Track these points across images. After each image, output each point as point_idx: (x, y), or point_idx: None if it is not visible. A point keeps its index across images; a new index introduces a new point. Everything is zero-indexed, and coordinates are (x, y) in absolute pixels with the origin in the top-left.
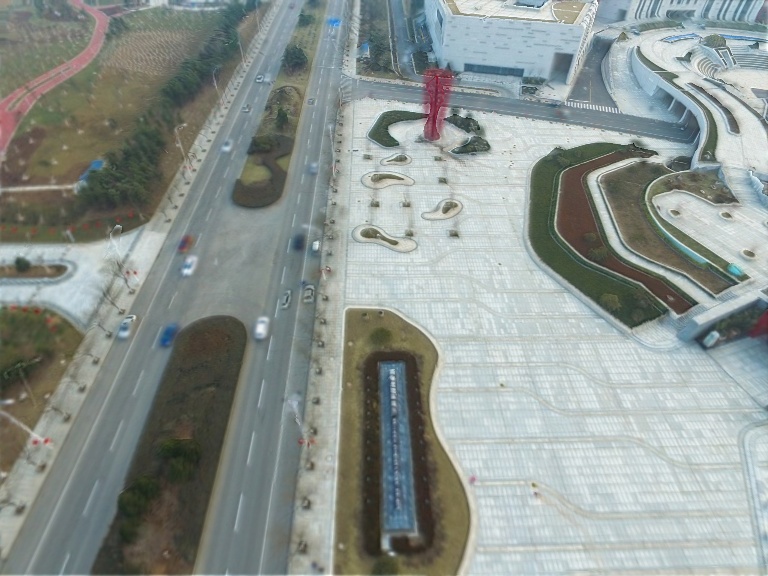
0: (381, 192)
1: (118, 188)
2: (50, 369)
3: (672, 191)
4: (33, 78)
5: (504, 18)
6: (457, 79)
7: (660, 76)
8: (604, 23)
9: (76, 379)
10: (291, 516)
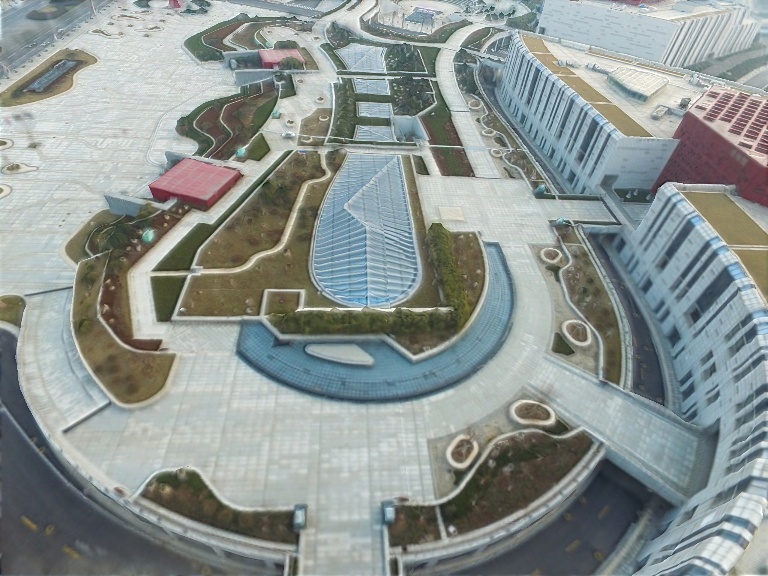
0: (119, 21)
1: None
2: None
3: (281, 27)
4: None
5: None
6: None
7: None
8: None
9: None
10: None
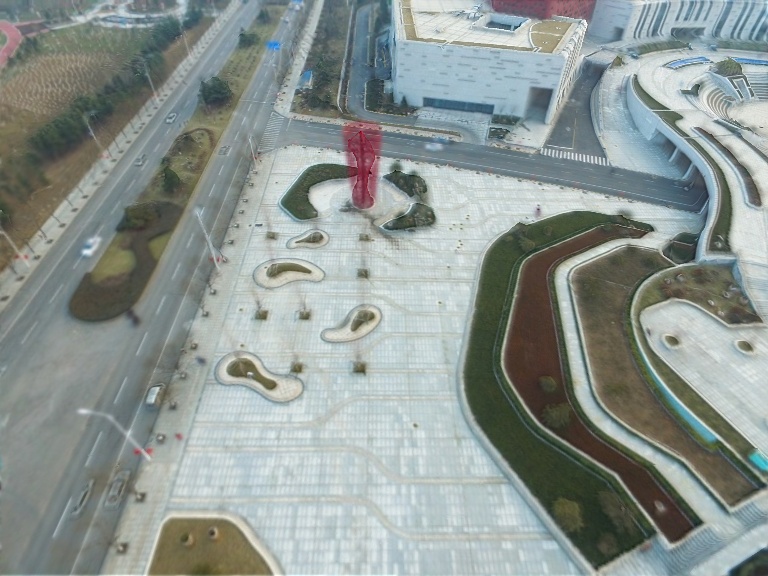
0: (275, 294)
1: None
2: None
3: (669, 300)
4: None
5: (468, 44)
6: (413, 117)
7: (660, 117)
8: (597, 43)
9: None
10: None
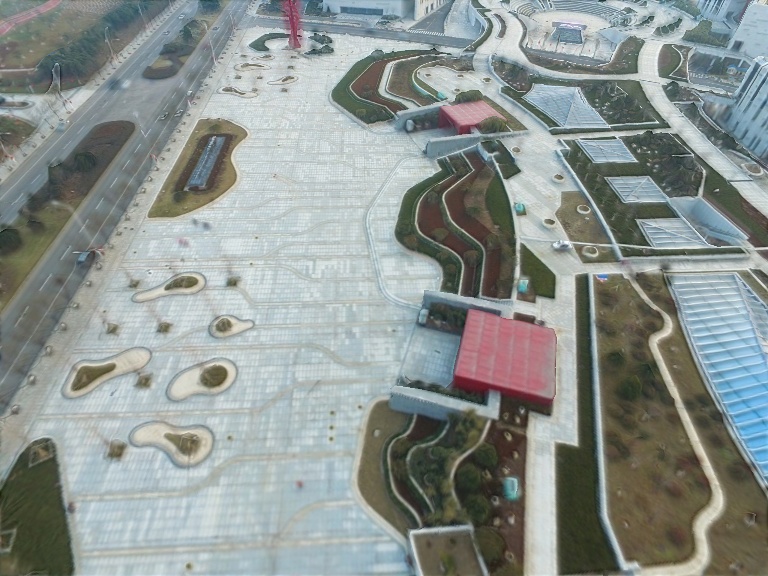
0: (245, 72)
1: (63, 62)
2: (16, 139)
3: (435, 66)
4: (10, 16)
5: None
6: (333, 17)
7: (477, 10)
8: None
9: (30, 140)
10: (141, 183)
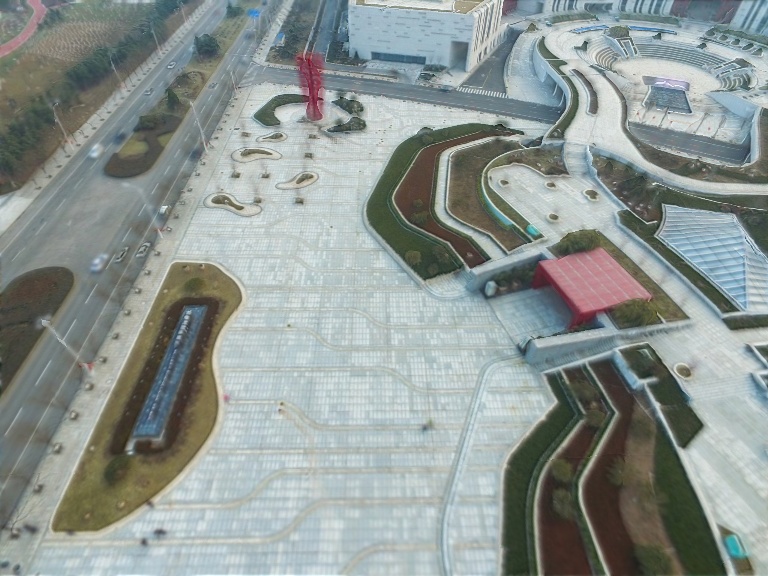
0: (246, 165)
1: None
2: None
3: (511, 164)
4: None
5: (403, 8)
6: (363, 66)
7: (549, 63)
8: (523, 15)
9: None
10: (57, 425)
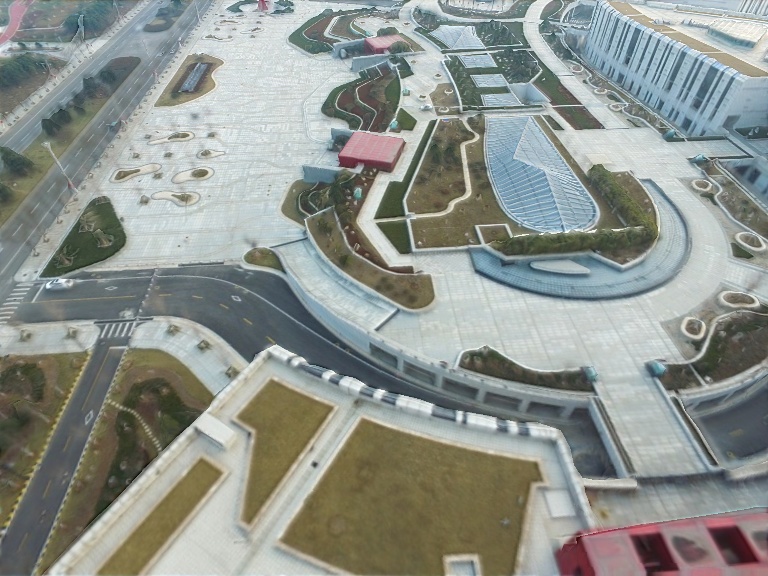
0: (223, 26)
1: (83, 19)
2: None
3: (370, 17)
4: None
5: None
6: None
7: None
8: None
9: (66, 68)
10: (148, 90)
